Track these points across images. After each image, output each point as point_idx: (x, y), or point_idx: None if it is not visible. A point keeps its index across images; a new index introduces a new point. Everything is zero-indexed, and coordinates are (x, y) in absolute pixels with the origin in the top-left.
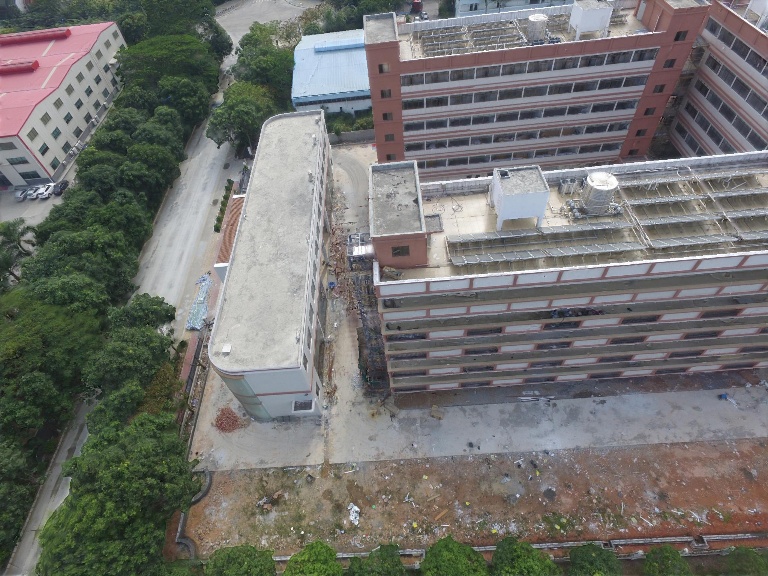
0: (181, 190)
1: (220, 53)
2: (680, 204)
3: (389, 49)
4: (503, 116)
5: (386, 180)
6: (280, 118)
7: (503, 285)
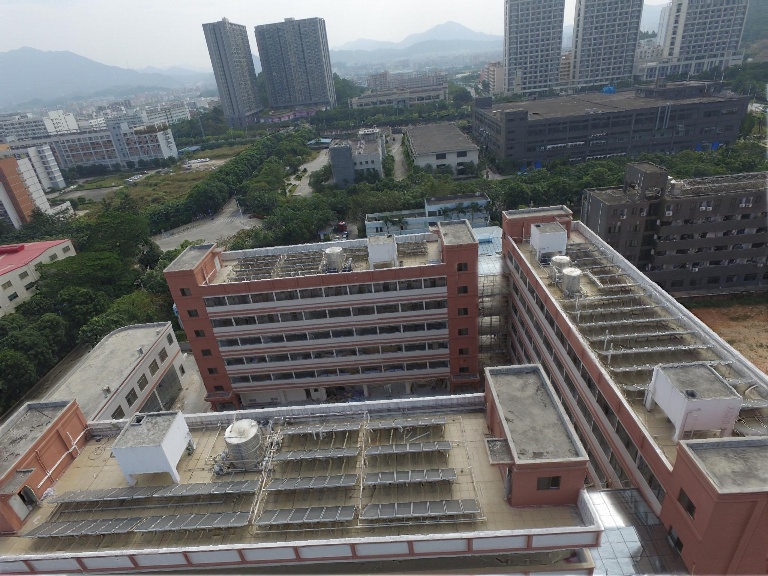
0: (39, 394)
1: (153, 264)
2: (344, 459)
3: (186, 276)
4: (315, 334)
5: (32, 420)
6: (129, 329)
7: (72, 569)
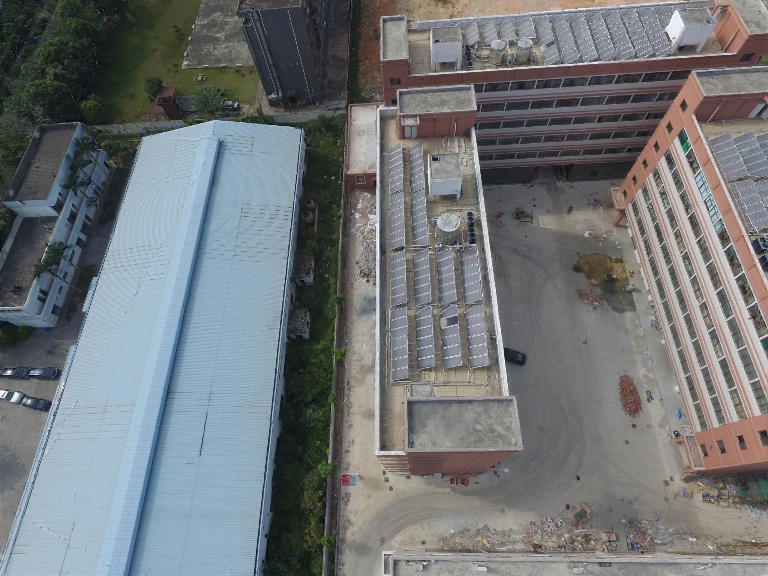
0: None
1: None
2: None
3: None
4: None
5: None
6: None
7: None
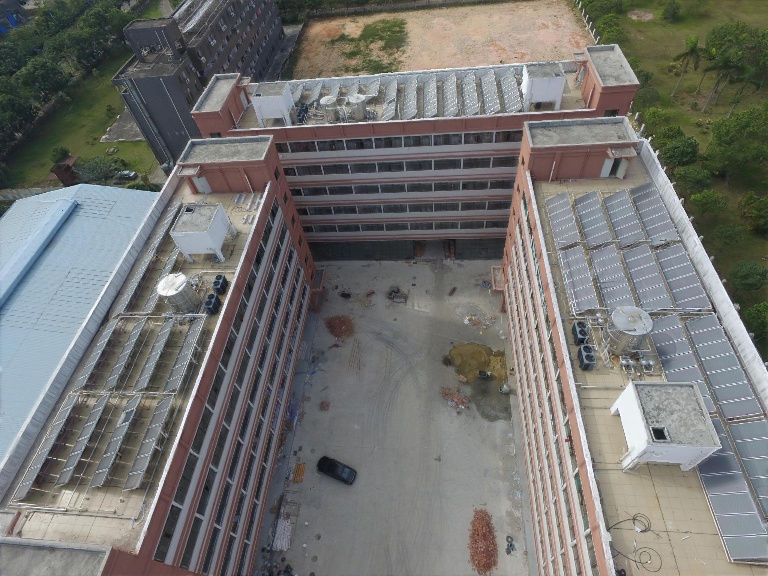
0: None
1: None
2: None
3: None
4: (252, 392)
5: None
6: None
7: None
